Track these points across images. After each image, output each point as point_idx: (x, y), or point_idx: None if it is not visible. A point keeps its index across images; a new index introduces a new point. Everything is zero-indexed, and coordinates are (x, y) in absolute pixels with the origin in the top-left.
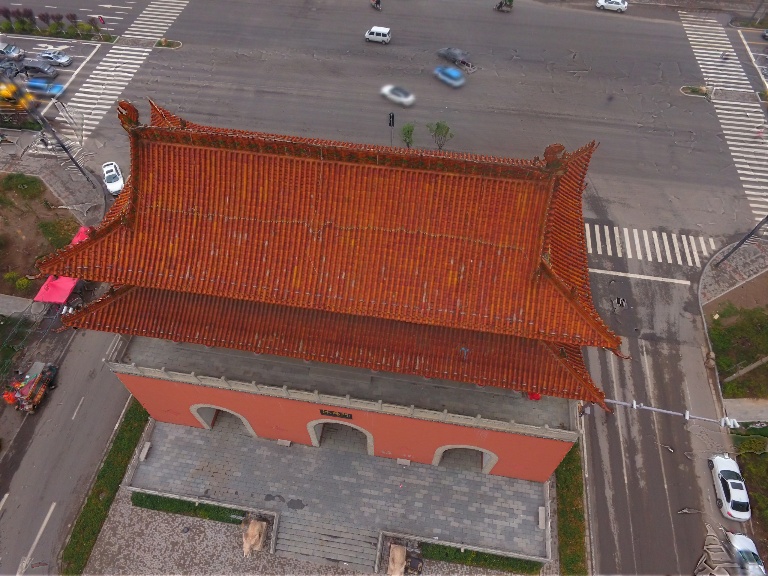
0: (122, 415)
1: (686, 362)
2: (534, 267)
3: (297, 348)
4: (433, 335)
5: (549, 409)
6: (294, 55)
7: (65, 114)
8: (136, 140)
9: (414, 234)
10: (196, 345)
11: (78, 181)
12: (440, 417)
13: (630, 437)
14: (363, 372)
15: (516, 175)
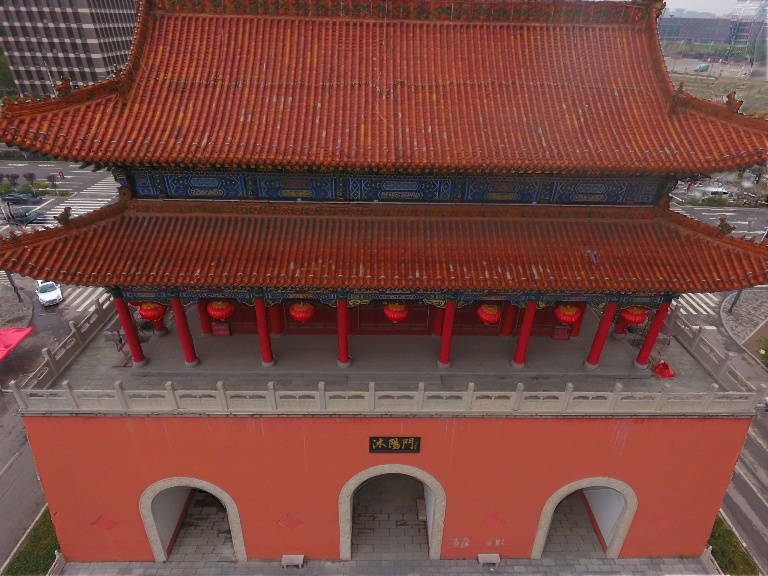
0: (2, 570)
1: (765, 396)
2: (665, 100)
3: (356, 273)
4: (543, 241)
5: (693, 385)
6: None
7: (7, 212)
8: (148, 8)
9: (509, 84)
10: (170, 366)
11: (0, 297)
12: (559, 407)
13: (763, 485)
14: (427, 370)
15: (609, 18)
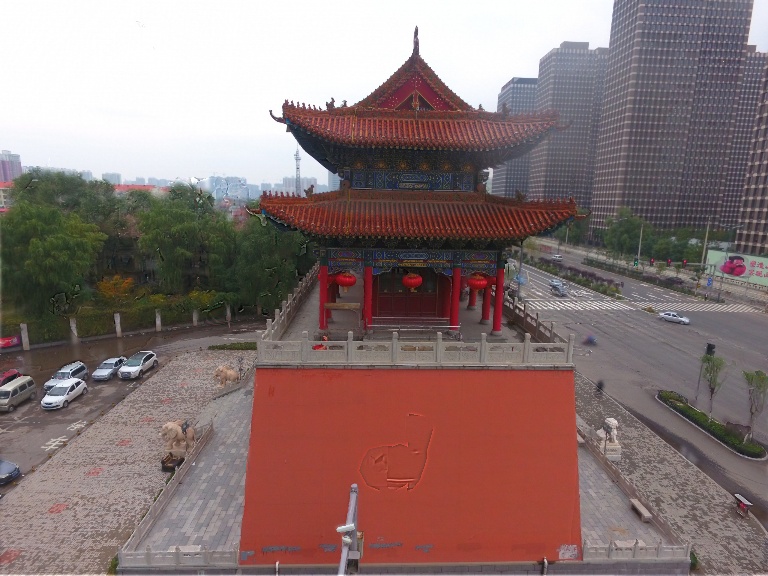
0: None
1: None
2: None
3: None
4: None
5: None
6: (747, 349)
7: (507, 266)
8: None
9: None
10: None
11: None
12: None
13: None
14: None
15: None
